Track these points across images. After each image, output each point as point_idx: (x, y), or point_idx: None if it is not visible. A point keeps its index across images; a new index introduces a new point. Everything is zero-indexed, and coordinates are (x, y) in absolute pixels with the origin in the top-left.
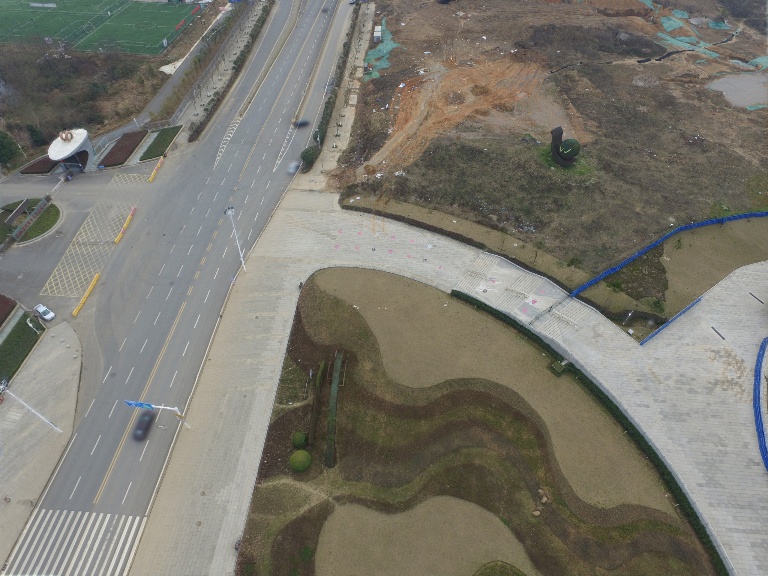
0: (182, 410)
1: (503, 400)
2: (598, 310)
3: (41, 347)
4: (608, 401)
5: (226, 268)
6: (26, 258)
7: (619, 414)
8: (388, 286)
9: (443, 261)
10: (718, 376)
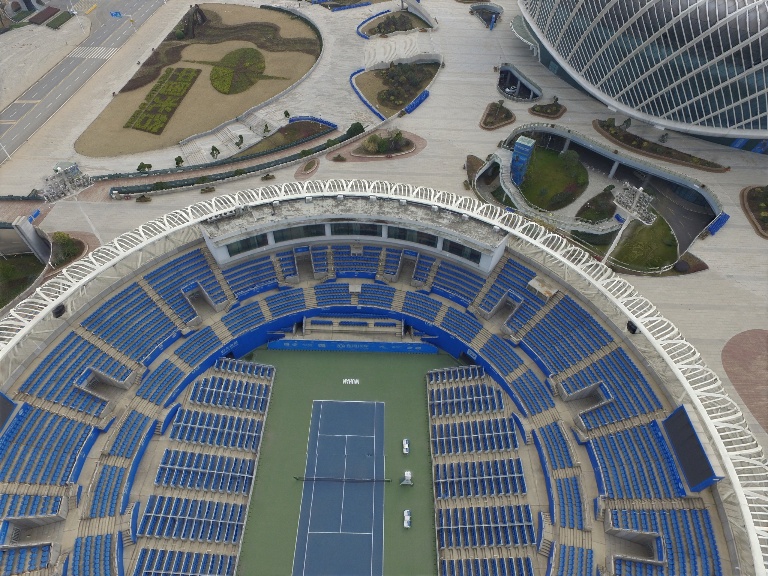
0: None
1: (267, 24)
2: (320, 4)
3: (73, 20)
4: (307, 20)
5: (157, 4)
6: (61, 2)
7: (309, 22)
8: (232, 7)
9: (262, 1)
10: (359, 17)
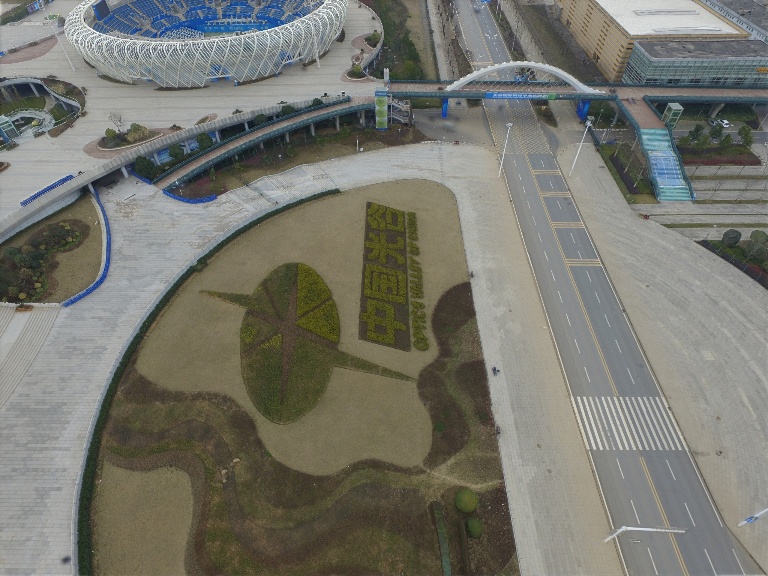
0: (629, 567)
1: None
2: None
3: None
4: None
5: None
6: None
7: (86, 575)
8: None
9: None
10: None
